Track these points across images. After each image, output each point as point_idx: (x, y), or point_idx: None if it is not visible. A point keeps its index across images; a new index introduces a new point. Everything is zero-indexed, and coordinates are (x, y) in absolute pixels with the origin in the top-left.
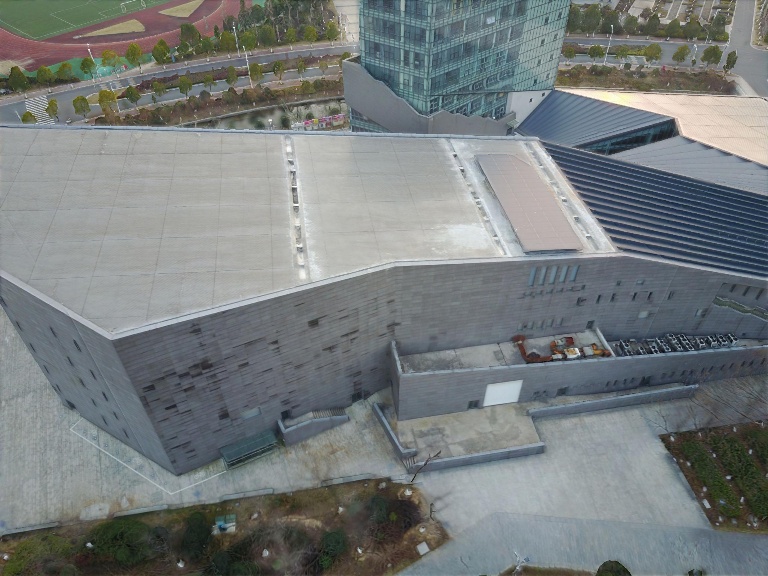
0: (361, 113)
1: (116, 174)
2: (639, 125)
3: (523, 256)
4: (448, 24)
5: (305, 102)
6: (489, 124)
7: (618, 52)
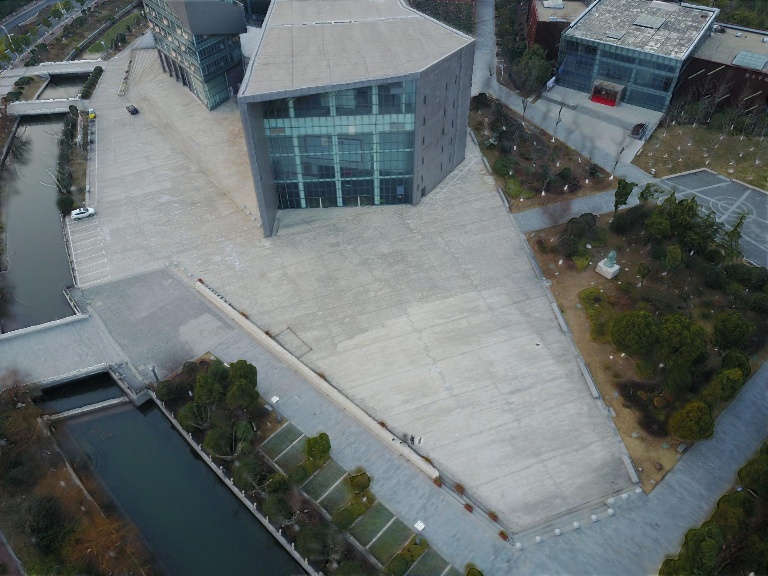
0: (203, 34)
1: None
2: None
3: None
4: None
5: (6, 151)
6: None
7: (66, 7)
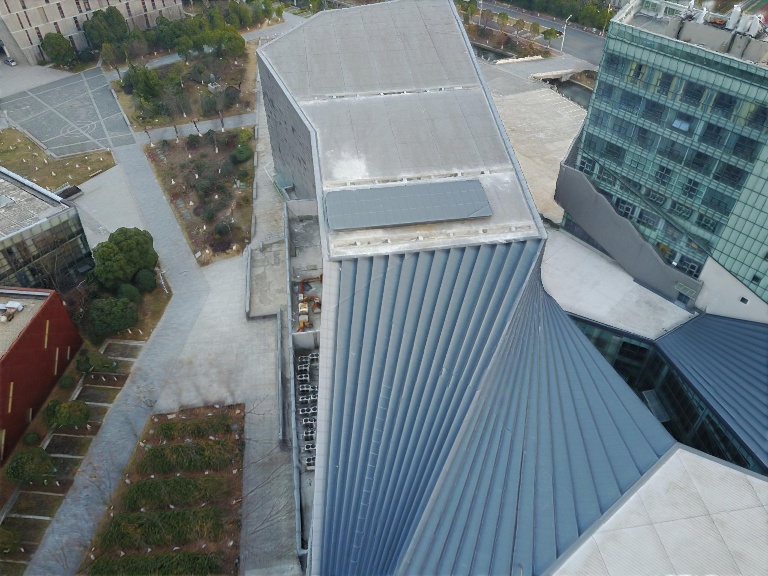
0: None
1: (404, 33)
2: (744, 433)
3: (324, 196)
4: (619, 87)
5: None
6: (648, 254)
7: None
